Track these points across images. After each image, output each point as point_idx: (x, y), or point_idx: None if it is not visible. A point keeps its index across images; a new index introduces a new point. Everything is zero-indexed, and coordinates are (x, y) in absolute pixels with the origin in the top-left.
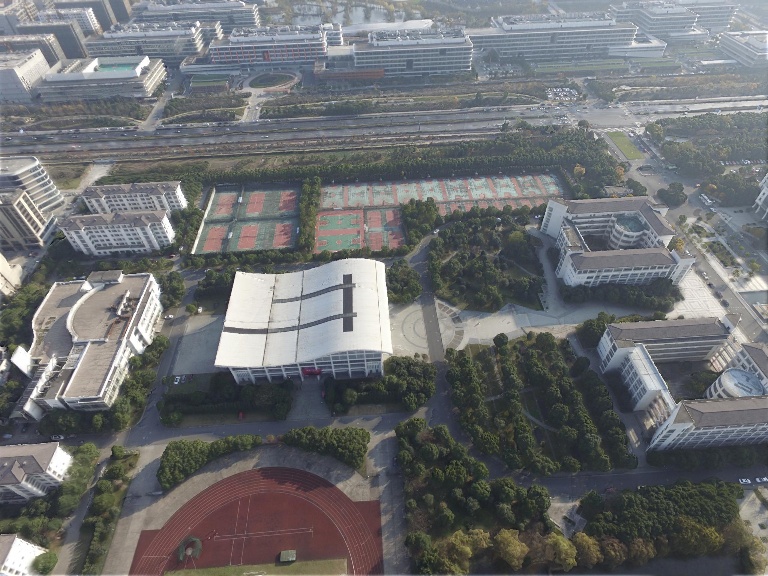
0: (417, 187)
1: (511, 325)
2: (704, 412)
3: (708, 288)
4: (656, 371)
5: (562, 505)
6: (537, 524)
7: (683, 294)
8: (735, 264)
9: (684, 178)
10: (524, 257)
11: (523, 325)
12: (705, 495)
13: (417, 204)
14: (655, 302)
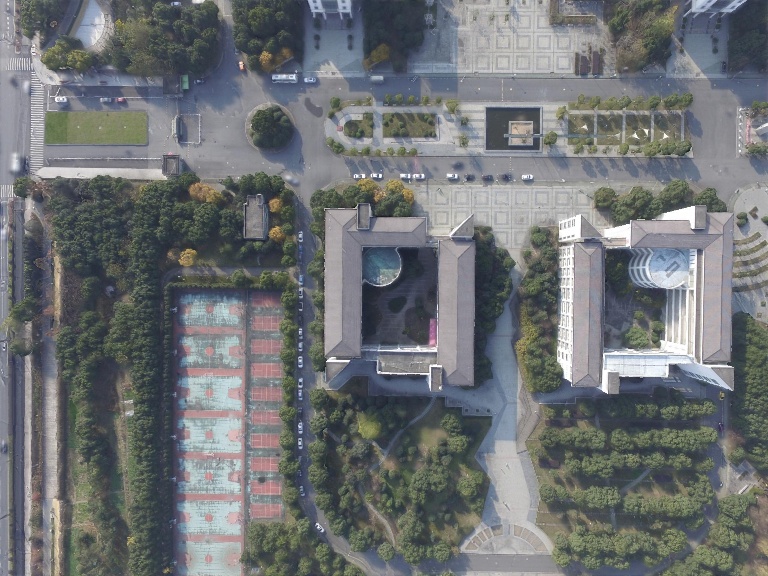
0: (198, 541)
1: (512, 465)
2: (720, 348)
3: (474, 185)
4: (643, 356)
5: (729, 477)
6: (752, 512)
7: (482, 224)
8: (434, 122)
9: (216, 77)
10: (405, 424)
11: (513, 450)
12: (763, 364)
13: (259, 557)
14: (510, 282)
